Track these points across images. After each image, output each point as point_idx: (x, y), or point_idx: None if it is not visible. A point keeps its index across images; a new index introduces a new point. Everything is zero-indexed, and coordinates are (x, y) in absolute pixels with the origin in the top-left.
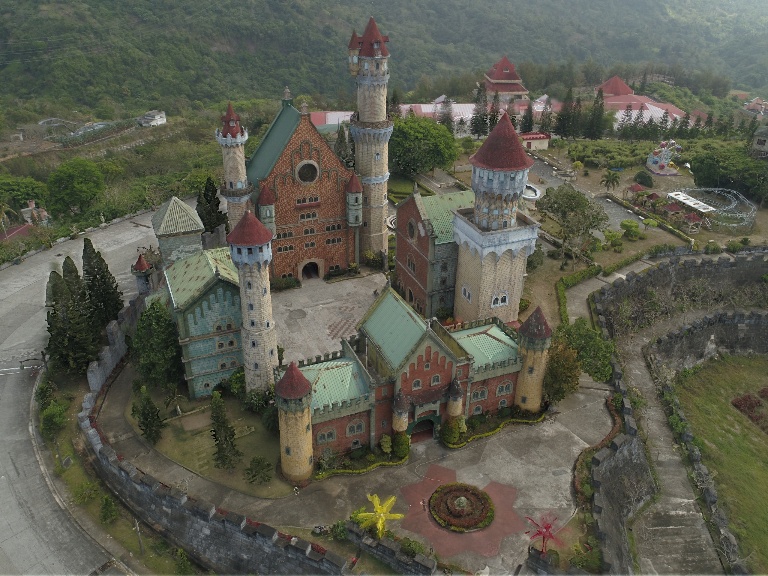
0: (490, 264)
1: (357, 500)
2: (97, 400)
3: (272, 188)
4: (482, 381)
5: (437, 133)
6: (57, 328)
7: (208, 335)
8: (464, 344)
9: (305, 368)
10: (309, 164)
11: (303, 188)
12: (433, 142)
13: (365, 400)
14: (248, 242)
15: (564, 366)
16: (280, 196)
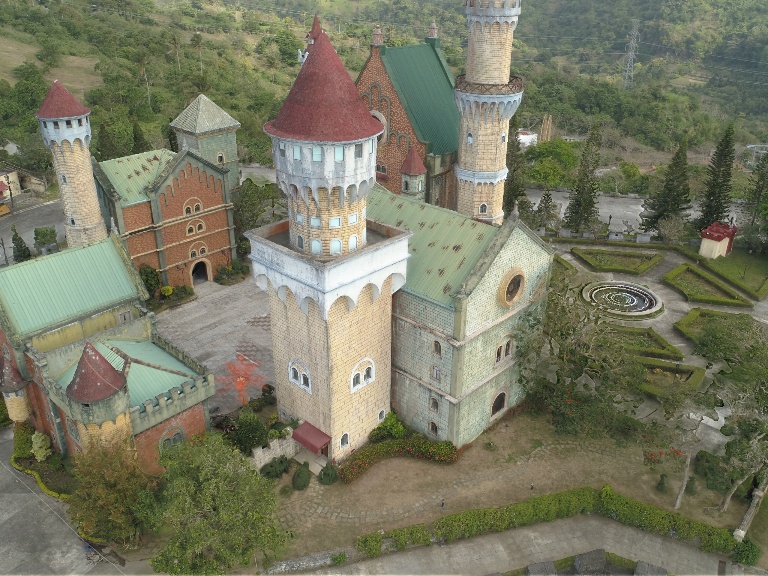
0: (279, 300)
1: None
2: None
3: None
4: None
5: None
6: None
7: None
8: None
9: None
10: (376, 117)
11: None
12: None
13: None
14: None
15: None
16: None
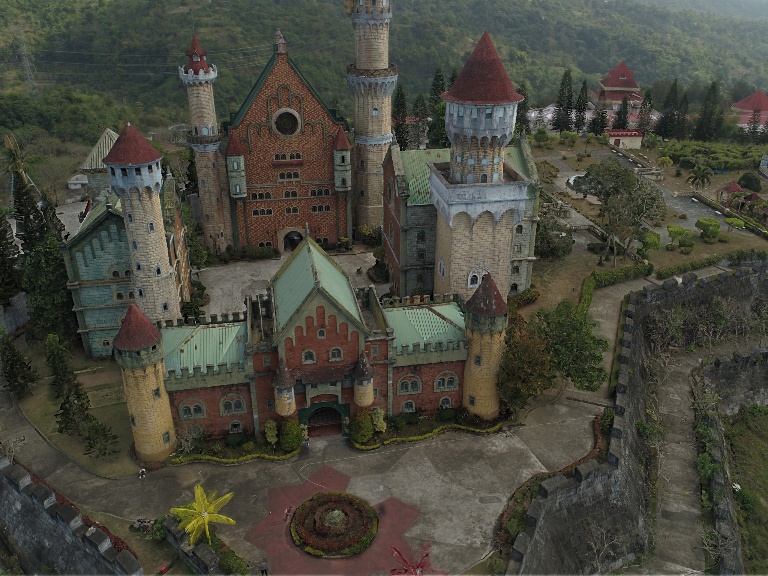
0: (463, 229)
1: (208, 495)
2: None
3: (244, 138)
4: (412, 367)
5: None
6: None
7: (102, 281)
8: (395, 318)
9: None
10: (288, 113)
11: (282, 142)
12: None
13: (239, 369)
14: (121, 160)
15: (521, 358)
16: (255, 149)
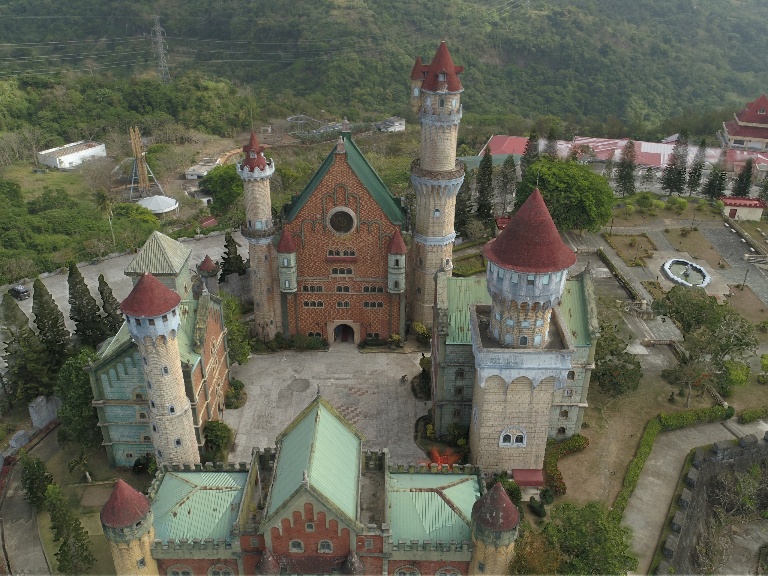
0: (497, 390)
1: None
2: (35, 438)
3: (298, 233)
4: (410, 560)
5: (586, 185)
6: (11, 353)
7: (126, 401)
8: (400, 500)
9: (192, 476)
10: (343, 212)
11: (336, 238)
12: (577, 196)
13: (227, 546)
14: (135, 311)
15: None
16: (308, 244)
